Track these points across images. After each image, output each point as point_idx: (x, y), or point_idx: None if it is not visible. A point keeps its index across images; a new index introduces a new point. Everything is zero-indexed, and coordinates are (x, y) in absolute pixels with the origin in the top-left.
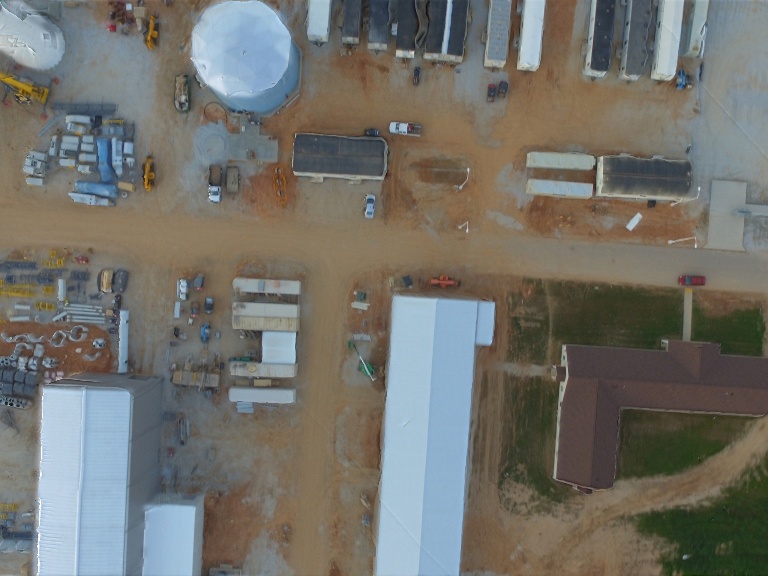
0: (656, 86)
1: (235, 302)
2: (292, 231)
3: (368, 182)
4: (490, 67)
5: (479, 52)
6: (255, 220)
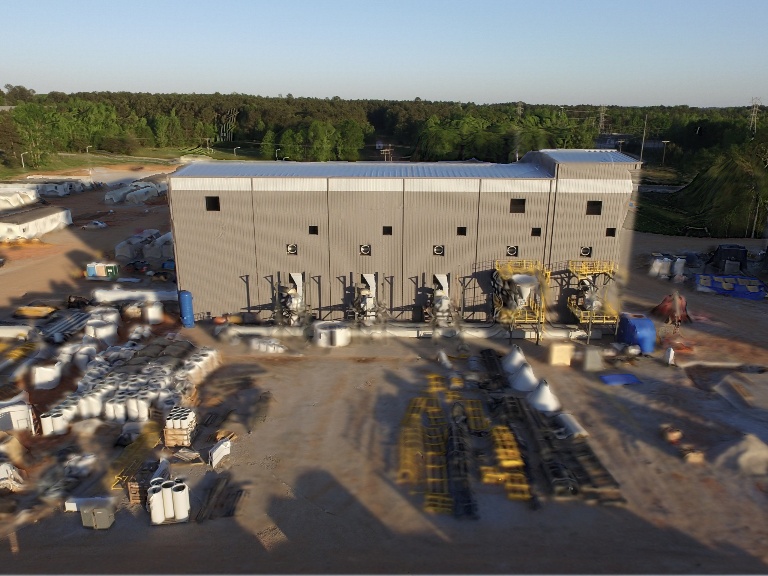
0: (94, 189)
1: (145, 245)
2: (86, 246)
3: (70, 227)
4: (18, 205)
5: (0, 204)
6: (53, 256)
